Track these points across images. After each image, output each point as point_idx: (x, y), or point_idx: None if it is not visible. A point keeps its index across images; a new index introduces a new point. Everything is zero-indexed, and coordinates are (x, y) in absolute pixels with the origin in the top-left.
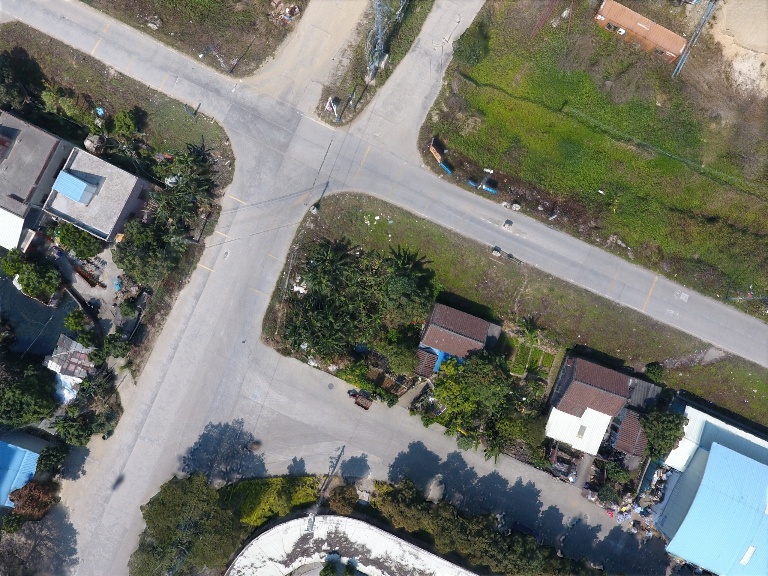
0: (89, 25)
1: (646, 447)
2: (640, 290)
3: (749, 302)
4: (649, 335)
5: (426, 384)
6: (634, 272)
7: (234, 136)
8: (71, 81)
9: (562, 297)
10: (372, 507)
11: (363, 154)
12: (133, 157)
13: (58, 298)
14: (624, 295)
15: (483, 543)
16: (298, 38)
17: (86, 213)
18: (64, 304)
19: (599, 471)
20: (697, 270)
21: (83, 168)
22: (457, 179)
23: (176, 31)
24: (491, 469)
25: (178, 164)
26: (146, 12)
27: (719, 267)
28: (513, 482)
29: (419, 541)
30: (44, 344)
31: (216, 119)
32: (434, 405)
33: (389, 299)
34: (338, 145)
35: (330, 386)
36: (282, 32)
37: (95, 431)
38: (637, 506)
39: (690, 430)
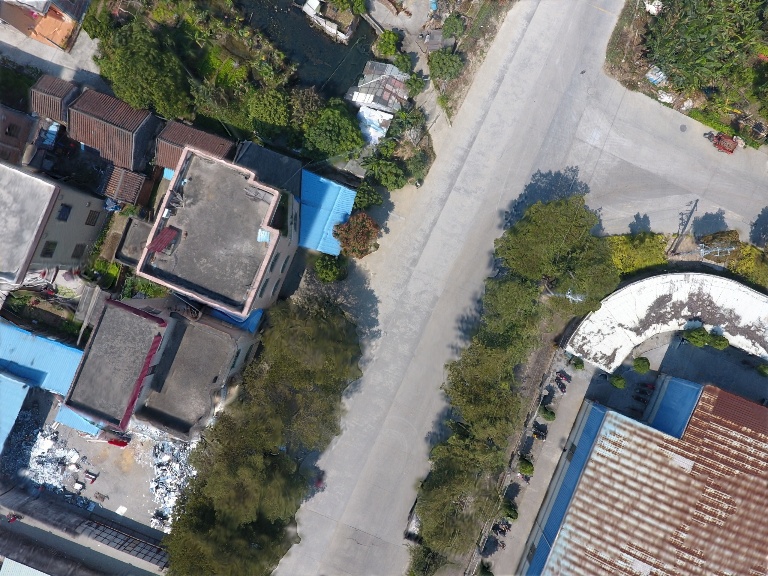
0: None
1: None
2: None
3: None
4: None
5: None
6: None
7: None
8: None
9: None
10: (731, 272)
11: None
12: None
13: (352, 30)
14: None
15: None
16: None
17: None
18: (355, 41)
19: None
20: None
21: None
22: None
23: None
24: None
25: None
26: None
27: None
28: None
29: None
30: (332, 87)
31: None
32: None
33: None
34: None
35: (682, 128)
36: None
37: (414, 171)
38: None
39: None
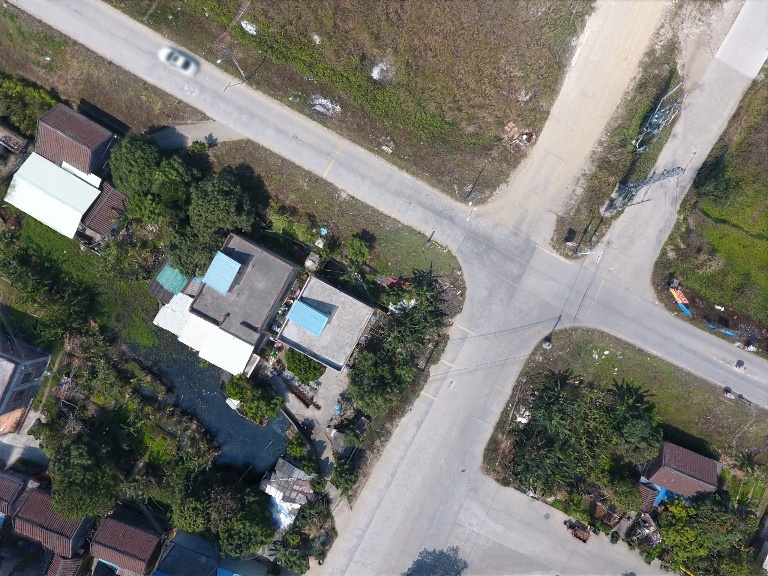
0: (322, 146)
1: None
2: None
3: None
4: None
5: None
6: None
7: (467, 266)
8: (297, 200)
9: None
10: None
11: (597, 288)
12: (359, 281)
13: None
14: None
15: None
16: (531, 164)
17: (317, 342)
18: (273, 421)
19: None
20: None
21: (315, 296)
22: (690, 317)
23: (409, 154)
24: None
25: (416, 297)
26: (378, 132)
27: None
28: None
29: None
30: (252, 461)
31: (450, 248)
32: (648, 537)
33: (625, 441)
34: (572, 278)
35: (546, 516)
36: (518, 159)
37: (316, 559)
38: None
39: None
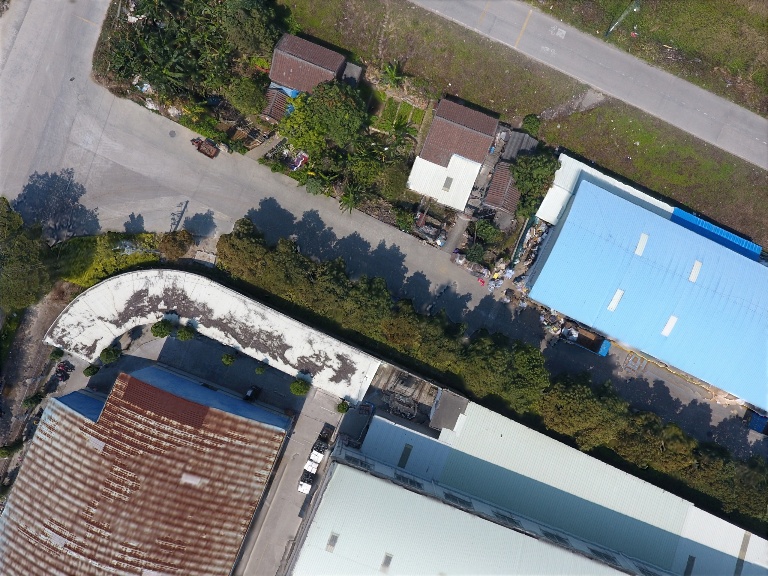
0: None
1: (518, 203)
2: (512, 24)
3: (631, 40)
4: (523, 78)
5: (283, 139)
6: (506, 4)
7: None
8: None
9: (427, 32)
10: (218, 269)
11: None
12: None
13: None
14: (495, 29)
15: (324, 281)
16: None
17: None
18: None
19: (472, 239)
20: (575, 3)
21: None
22: None
23: None
24: (351, 230)
25: None
26: None
27: (600, 2)
28: (375, 245)
29: (269, 304)
30: None
31: None
32: (288, 158)
33: None
34: None
35: (171, 134)
36: None
37: None
38: (508, 269)
39: (563, 178)
